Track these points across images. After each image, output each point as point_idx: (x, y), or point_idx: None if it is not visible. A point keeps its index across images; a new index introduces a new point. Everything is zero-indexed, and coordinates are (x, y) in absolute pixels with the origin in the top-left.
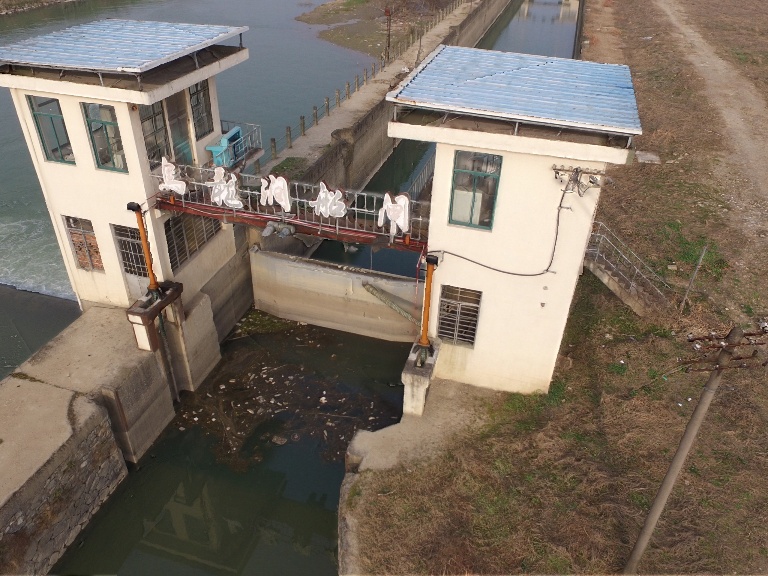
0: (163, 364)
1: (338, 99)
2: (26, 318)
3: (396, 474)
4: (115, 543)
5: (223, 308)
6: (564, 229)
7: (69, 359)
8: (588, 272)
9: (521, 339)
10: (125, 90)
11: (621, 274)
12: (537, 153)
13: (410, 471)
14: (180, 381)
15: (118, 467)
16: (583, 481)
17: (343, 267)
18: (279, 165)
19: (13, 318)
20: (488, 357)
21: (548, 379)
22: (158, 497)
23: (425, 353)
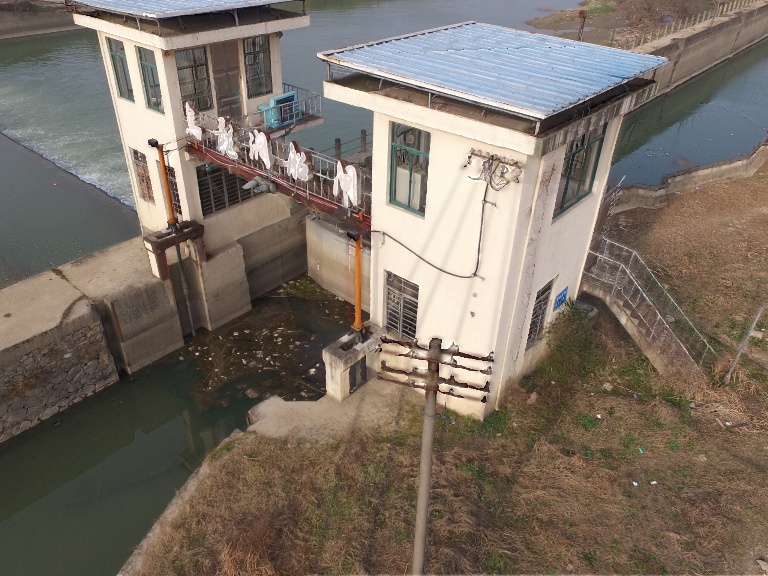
0: (174, 294)
1: None
2: None
3: (273, 444)
4: (98, 437)
5: (267, 265)
6: (490, 228)
7: (99, 269)
8: None
9: None
10: (151, 34)
11: (641, 316)
12: (448, 131)
13: (289, 446)
14: (201, 318)
15: (108, 371)
16: (443, 518)
17: None
18: None
19: (125, 238)
20: None
21: (482, 404)
22: (155, 414)
23: (359, 338)
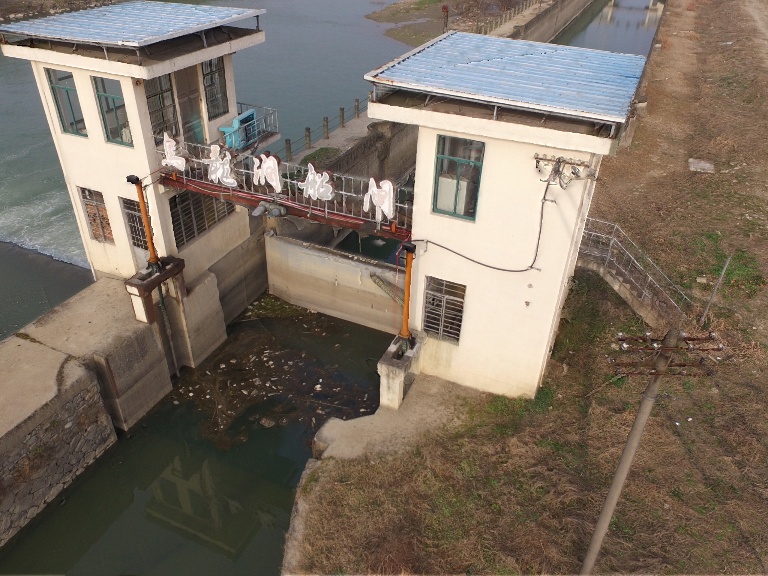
0: (160, 337)
1: None
2: (56, 286)
3: (358, 464)
4: (101, 506)
5: (234, 289)
6: (549, 223)
7: (70, 324)
8: None
9: (506, 339)
10: (126, 64)
11: (633, 281)
12: (516, 140)
13: (373, 463)
14: (182, 356)
15: (106, 432)
16: (550, 492)
17: (354, 257)
18: (311, 154)
19: (44, 285)
20: (473, 355)
21: (534, 383)
22: (150, 467)
23: (406, 345)
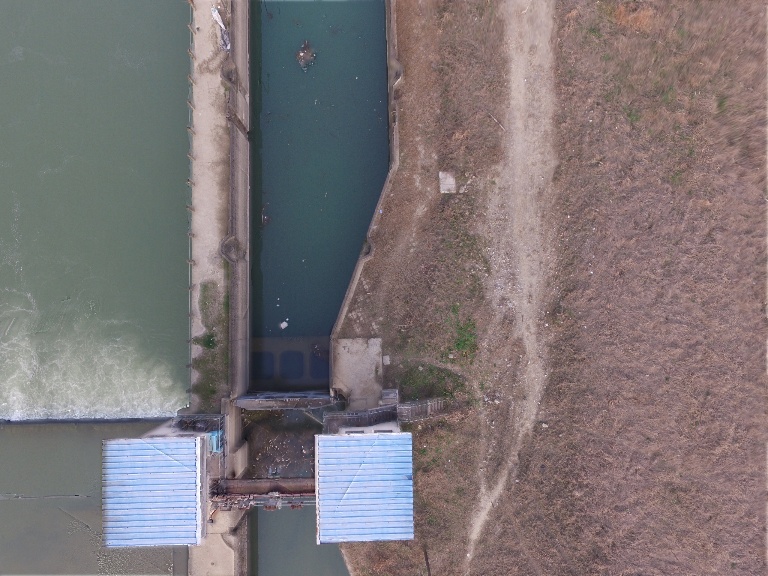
0: None
1: (191, 158)
2: None
3: None
4: None
5: None
6: None
7: None
8: (409, 372)
9: None
10: None
11: None
12: None
13: None
14: None
15: (244, 521)
16: None
17: (286, 400)
18: (201, 300)
19: None
20: None
21: None
22: None
23: None
